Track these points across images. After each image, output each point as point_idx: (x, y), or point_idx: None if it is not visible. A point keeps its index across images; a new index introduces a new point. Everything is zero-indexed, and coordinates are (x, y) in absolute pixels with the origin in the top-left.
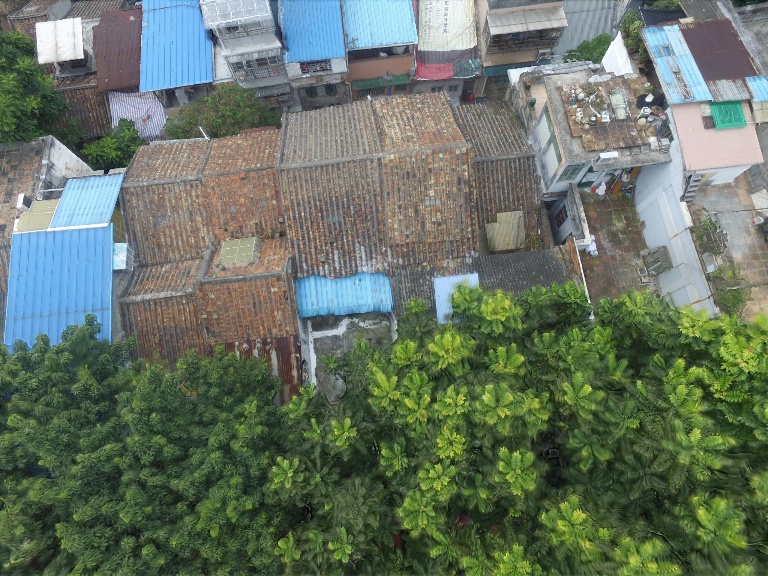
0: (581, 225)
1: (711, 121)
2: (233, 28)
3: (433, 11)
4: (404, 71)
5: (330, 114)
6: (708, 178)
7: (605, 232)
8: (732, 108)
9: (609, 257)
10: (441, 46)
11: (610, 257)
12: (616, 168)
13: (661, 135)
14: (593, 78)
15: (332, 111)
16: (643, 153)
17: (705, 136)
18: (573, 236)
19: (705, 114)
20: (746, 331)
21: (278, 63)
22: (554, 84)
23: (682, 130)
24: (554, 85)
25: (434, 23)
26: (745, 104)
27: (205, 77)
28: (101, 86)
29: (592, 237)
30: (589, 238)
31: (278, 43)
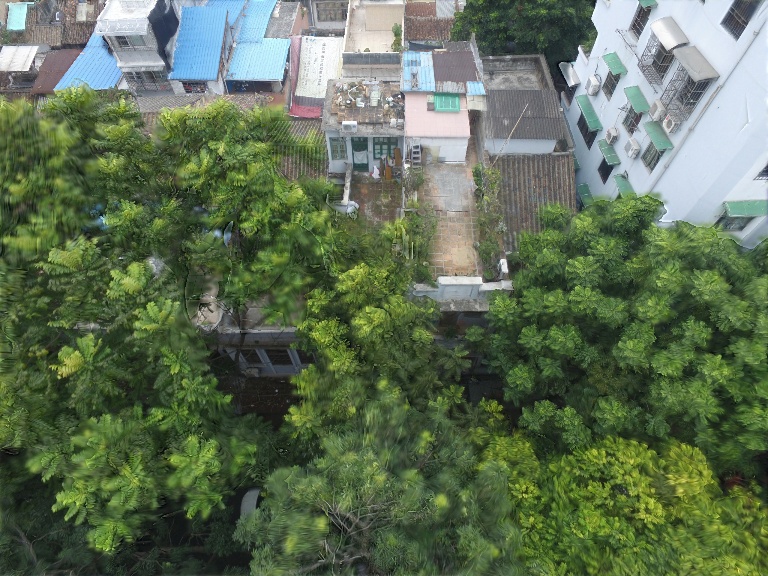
0: (344, 191)
1: (433, 106)
2: (122, 42)
3: (310, 69)
4: (280, 108)
5: (169, 98)
6: (438, 154)
7: (370, 204)
8: (451, 99)
9: (367, 222)
10: (314, 94)
11: (368, 222)
12: (359, 136)
13: (400, 117)
14: (364, 82)
15: (172, 97)
16: (383, 129)
17: (426, 115)
18: (331, 196)
19: (429, 101)
20: (440, 265)
21: (163, 78)
22: (333, 84)
23: (409, 110)
24: (333, 84)
25: (310, 77)
26: (464, 98)
27: (108, 86)
28: (33, 90)
29: (352, 202)
30: (346, 200)
31: (162, 62)
